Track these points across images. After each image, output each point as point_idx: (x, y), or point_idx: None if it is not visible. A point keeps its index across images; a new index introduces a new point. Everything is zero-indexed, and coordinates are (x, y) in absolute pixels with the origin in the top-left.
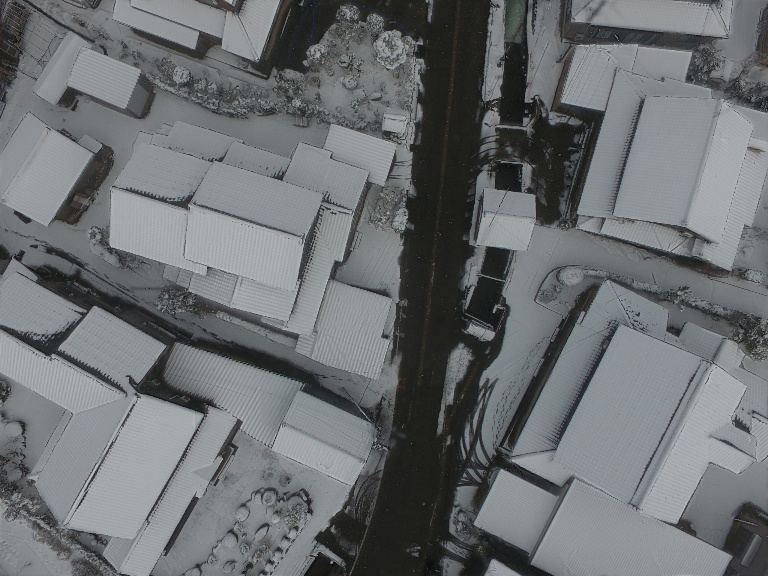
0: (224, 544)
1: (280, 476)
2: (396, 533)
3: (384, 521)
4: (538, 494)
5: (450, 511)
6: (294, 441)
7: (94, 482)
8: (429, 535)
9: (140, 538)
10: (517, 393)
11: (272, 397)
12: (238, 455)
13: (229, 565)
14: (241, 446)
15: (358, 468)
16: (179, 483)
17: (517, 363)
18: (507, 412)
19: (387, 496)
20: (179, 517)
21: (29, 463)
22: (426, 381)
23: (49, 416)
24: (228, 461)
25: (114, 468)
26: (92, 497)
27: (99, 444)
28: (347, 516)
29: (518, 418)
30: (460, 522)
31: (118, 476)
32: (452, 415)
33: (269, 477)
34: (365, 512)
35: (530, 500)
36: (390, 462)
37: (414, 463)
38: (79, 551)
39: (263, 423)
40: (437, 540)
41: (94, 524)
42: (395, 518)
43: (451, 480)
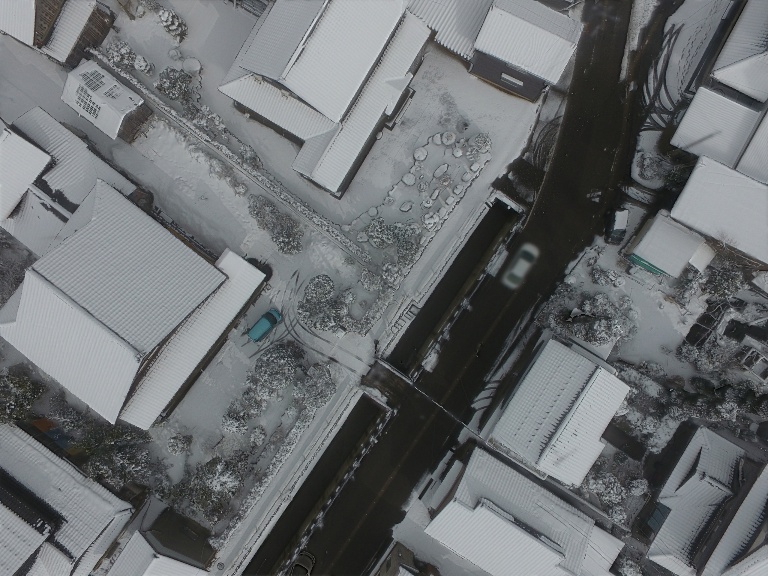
0: (400, 186)
1: (457, 122)
2: (575, 180)
3: (563, 167)
4: (739, 110)
5: (632, 156)
6: (501, 29)
7: (311, 39)
8: (610, 180)
9: (333, 144)
10: (704, 38)
11: (468, 7)
12: (415, 99)
13: (407, 203)
14: (418, 90)
15: (567, 56)
16: (372, 91)
17: (704, 8)
18: (693, 57)
19: (567, 142)
20: (369, 130)
21: (204, 104)
22: (610, 25)
23: (225, 57)
24: (405, 104)
25: (330, 29)
26: (307, 56)
27: (316, 3)
28: (525, 162)
29: (706, 61)
30: (647, 158)
31: (332, 40)
32: (635, 61)
33: (446, 122)
34: (544, 158)
35: (730, 116)
36: (570, 108)
37: (595, 109)
38: (260, 178)
39: (458, 33)
40: (618, 185)
41: (306, 89)
42: (575, 164)
43: (634, 125)
